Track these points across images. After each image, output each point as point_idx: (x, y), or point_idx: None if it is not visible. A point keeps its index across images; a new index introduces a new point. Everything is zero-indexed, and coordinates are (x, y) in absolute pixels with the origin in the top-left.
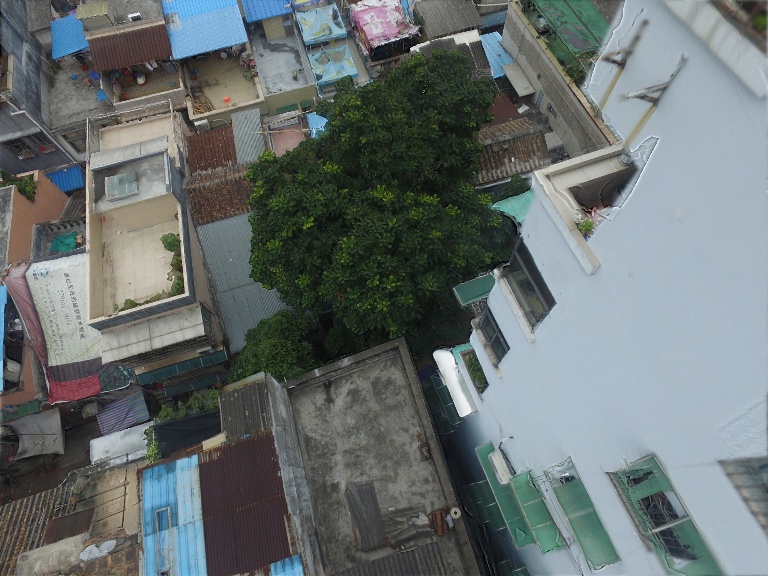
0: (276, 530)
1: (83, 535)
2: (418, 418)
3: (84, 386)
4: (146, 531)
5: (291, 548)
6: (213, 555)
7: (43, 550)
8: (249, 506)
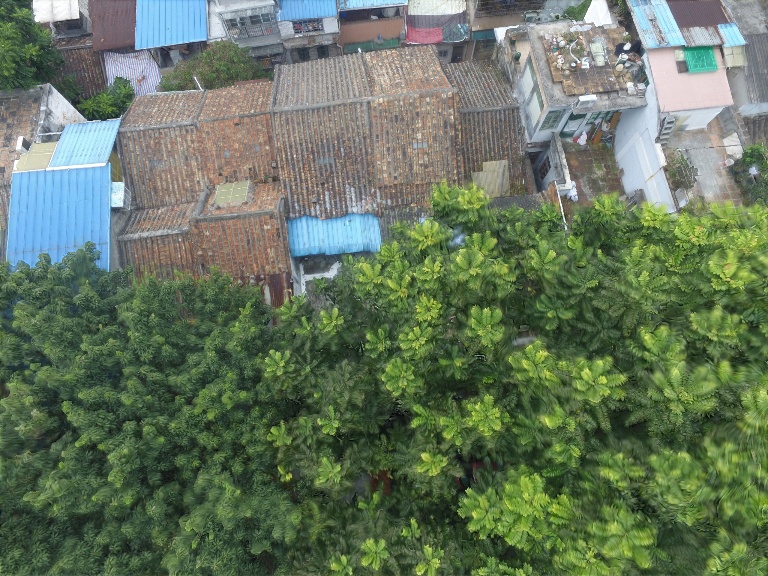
0: (717, 12)
1: (567, 23)
2: (765, 11)
3: (432, 34)
4: (633, 4)
5: (729, 19)
6: (679, 18)
7: (543, 26)
8: (696, 1)
